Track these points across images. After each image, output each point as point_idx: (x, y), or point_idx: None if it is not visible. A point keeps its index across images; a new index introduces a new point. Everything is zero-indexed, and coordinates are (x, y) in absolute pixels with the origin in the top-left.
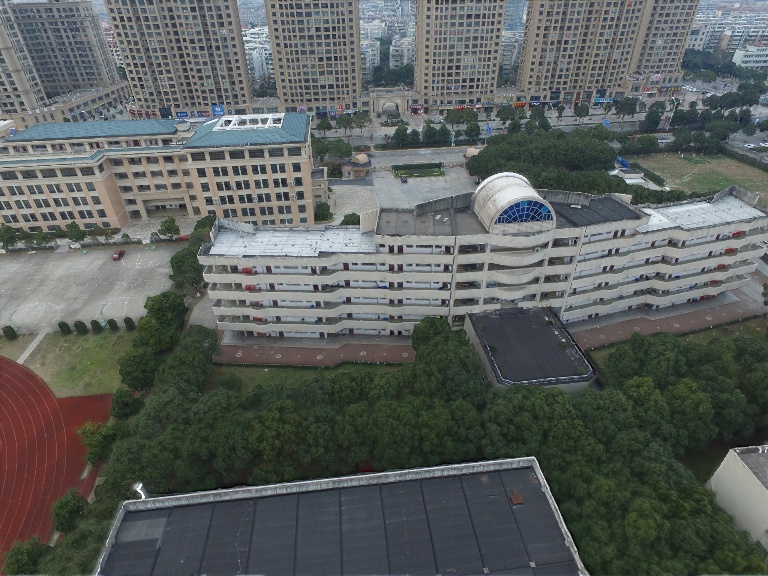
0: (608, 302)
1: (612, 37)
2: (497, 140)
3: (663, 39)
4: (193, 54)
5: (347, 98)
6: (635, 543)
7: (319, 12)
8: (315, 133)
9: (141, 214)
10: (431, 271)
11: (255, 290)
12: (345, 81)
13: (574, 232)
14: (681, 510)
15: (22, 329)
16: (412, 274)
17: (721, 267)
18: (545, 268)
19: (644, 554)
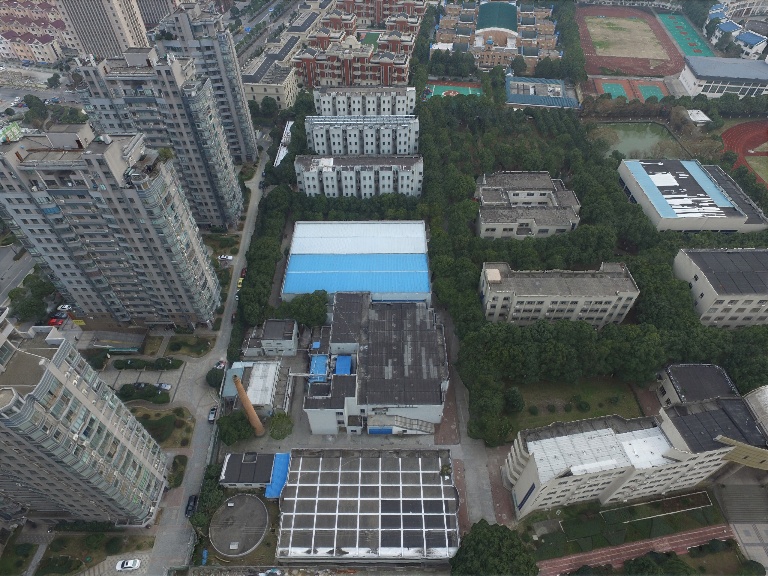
0: None
1: None
2: None
3: None
4: None
5: None
6: None
7: None
8: None
9: None
10: None
11: None
12: None
13: (725, 399)
14: None
15: None
16: None
17: None
18: None
19: None
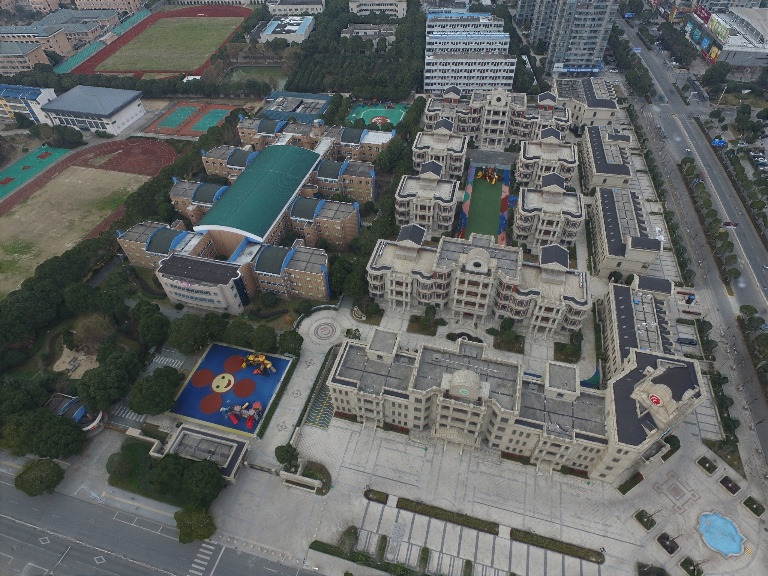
0: None
1: None
2: None
3: None
4: None
5: None
6: None
7: None
8: None
9: None
10: None
11: None
12: None
13: None
14: None
15: (241, 3)
16: None
17: None
18: None
19: None
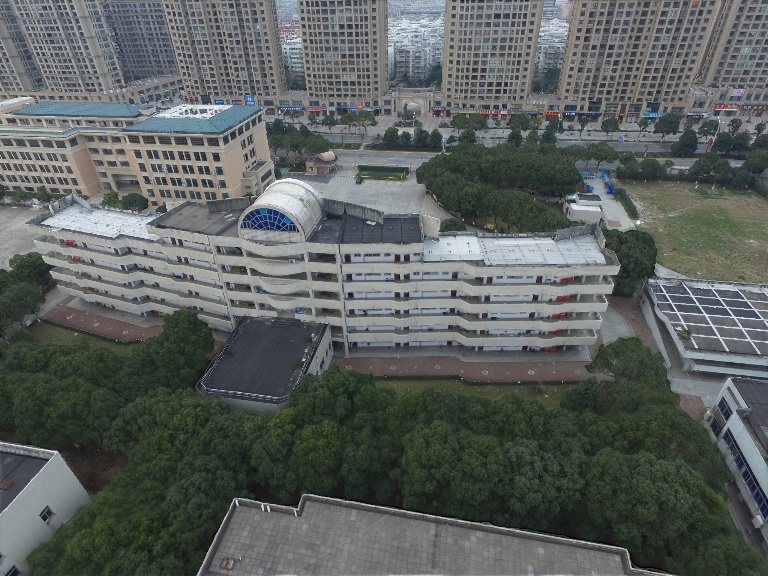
0: (409, 332)
1: (671, 43)
2: (456, 149)
3: (751, 47)
4: (230, 47)
5: (368, 96)
6: (65, 557)
7: (343, 10)
8: (326, 128)
9: (112, 186)
10: (211, 268)
11: (79, 261)
12: (367, 79)
13: (327, 248)
14: (134, 541)
15: None
16: (187, 267)
17: (556, 316)
18: (310, 282)
19: (64, 570)
